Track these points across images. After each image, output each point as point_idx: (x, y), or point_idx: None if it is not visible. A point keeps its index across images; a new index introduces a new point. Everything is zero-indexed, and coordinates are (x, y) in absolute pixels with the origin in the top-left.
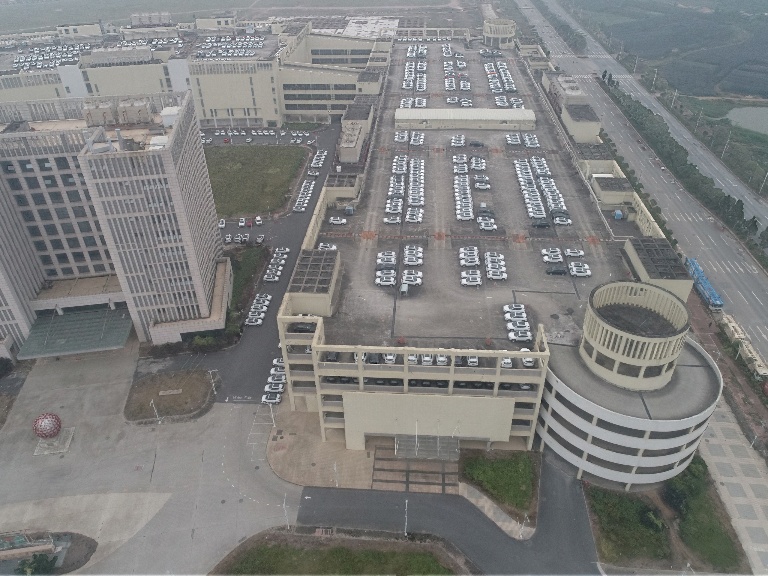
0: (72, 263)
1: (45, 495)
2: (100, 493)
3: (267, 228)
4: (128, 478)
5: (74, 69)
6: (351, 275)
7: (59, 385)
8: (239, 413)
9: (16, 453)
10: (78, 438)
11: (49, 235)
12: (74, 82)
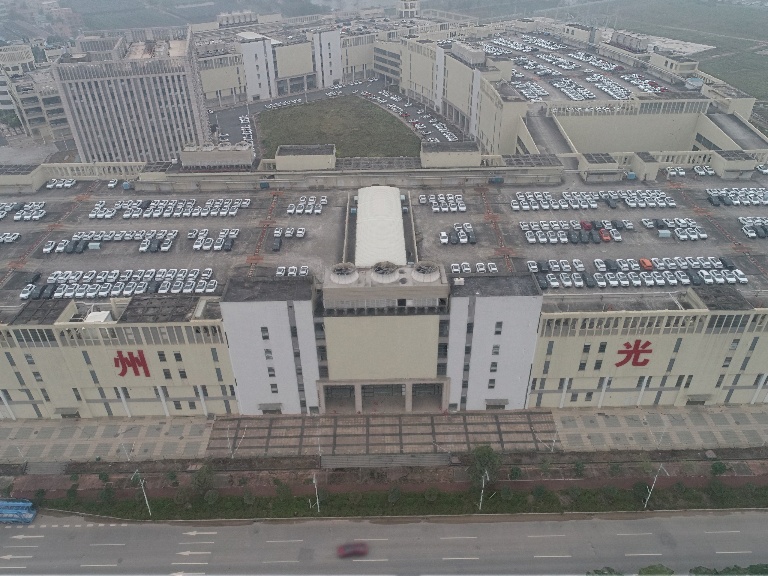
0: None
1: None
2: None
3: None
4: None
5: (442, 52)
6: (26, 196)
7: None
8: None
9: None
10: None
11: None
12: None
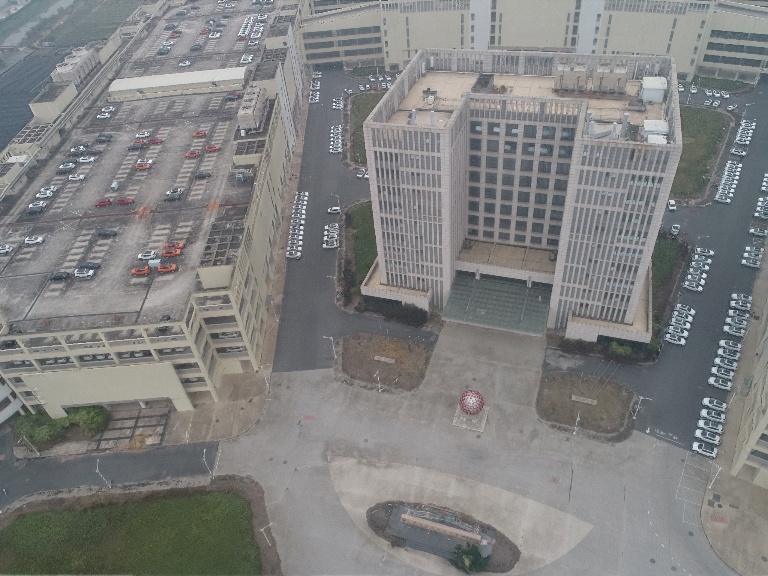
0: (496, 228)
1: (466, 474)
2: (518, 494)
3: (682, 216)
4: (545, 488)
5: None
6: None
7: (470, 353)
8: (664, 453)
9: (436, 416)
10: (492, 421)
11: (486, 198)
12: (481, 9)
